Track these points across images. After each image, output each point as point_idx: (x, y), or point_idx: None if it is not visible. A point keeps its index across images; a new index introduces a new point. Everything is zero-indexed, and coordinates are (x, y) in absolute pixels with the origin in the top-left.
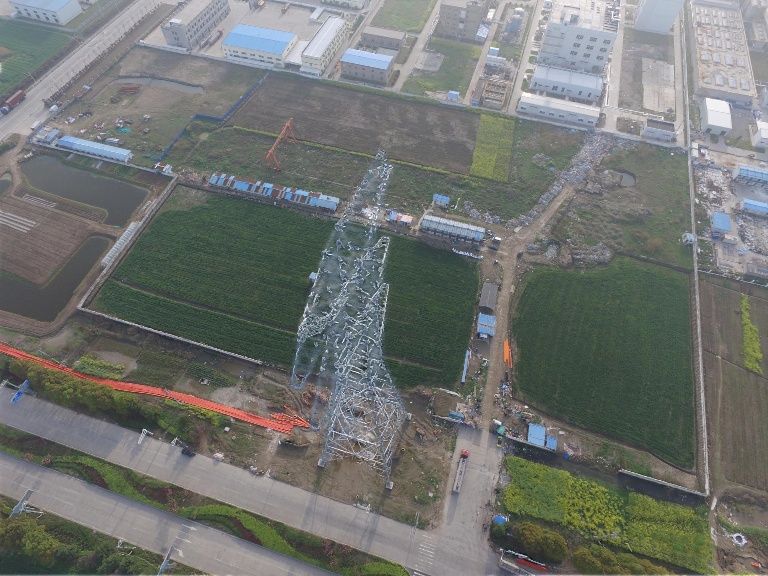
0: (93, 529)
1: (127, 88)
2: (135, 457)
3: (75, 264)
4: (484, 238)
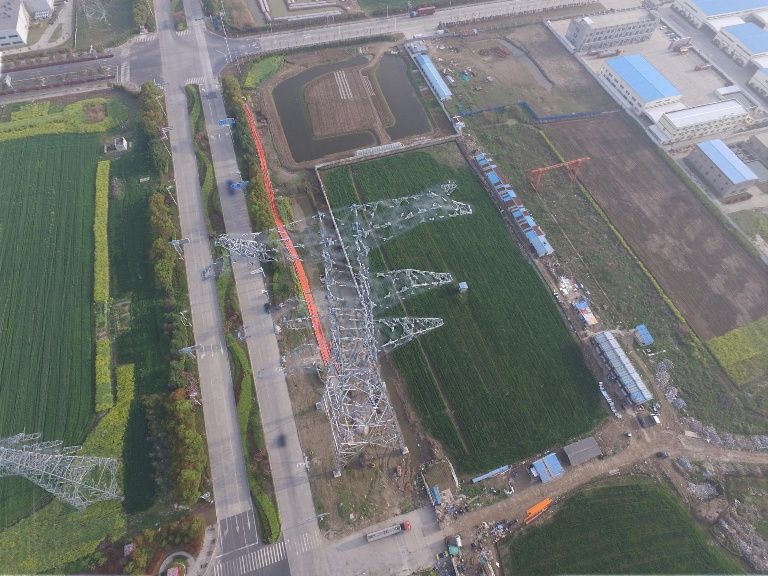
0: (189, 293)
1: (500, 49)
2: (245, 279)
3: (344, 140)
4: (644, 405)
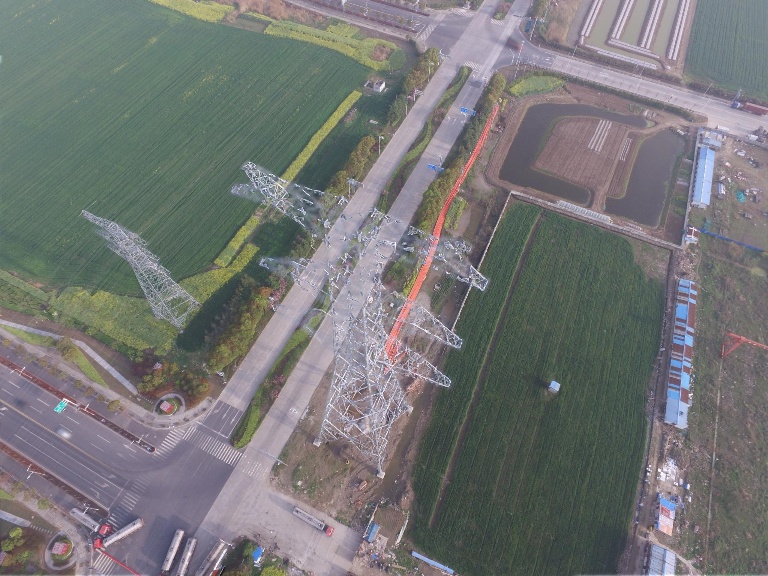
0: None
1: None
2: None
3: (558, 184)
4: None
